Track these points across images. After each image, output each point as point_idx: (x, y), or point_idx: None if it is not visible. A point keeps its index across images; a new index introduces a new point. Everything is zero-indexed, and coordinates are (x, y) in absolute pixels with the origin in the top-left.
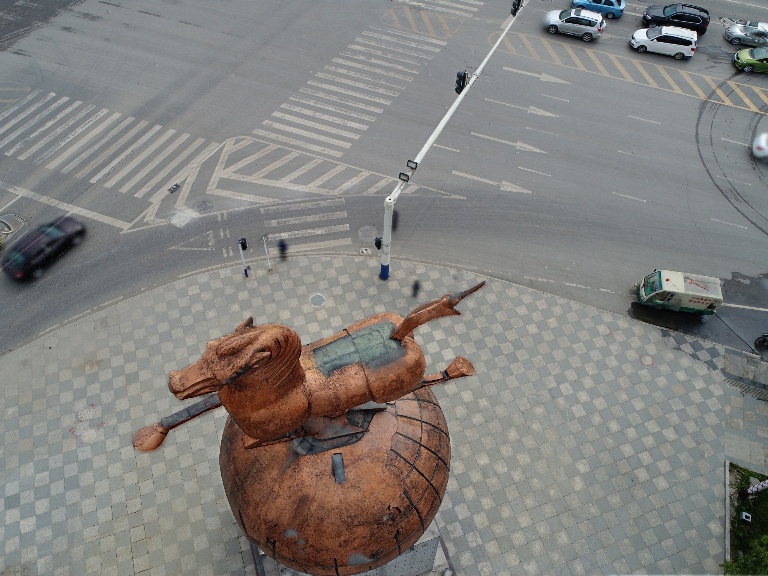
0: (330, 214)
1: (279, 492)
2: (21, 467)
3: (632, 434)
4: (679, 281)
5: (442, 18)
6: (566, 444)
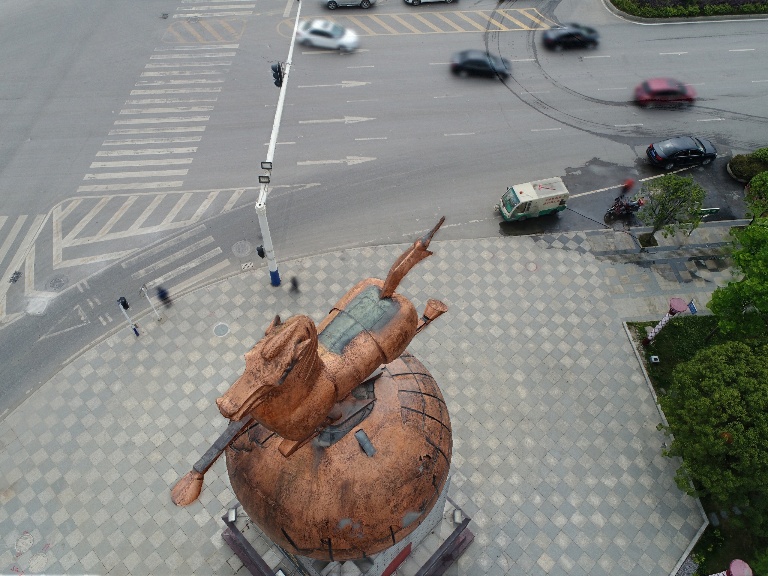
0: (196, 244)
1: (319, 491)
2: None
3: (546, 332)
4: (530, 190)
5: (224, 22)
6: (498, 364)
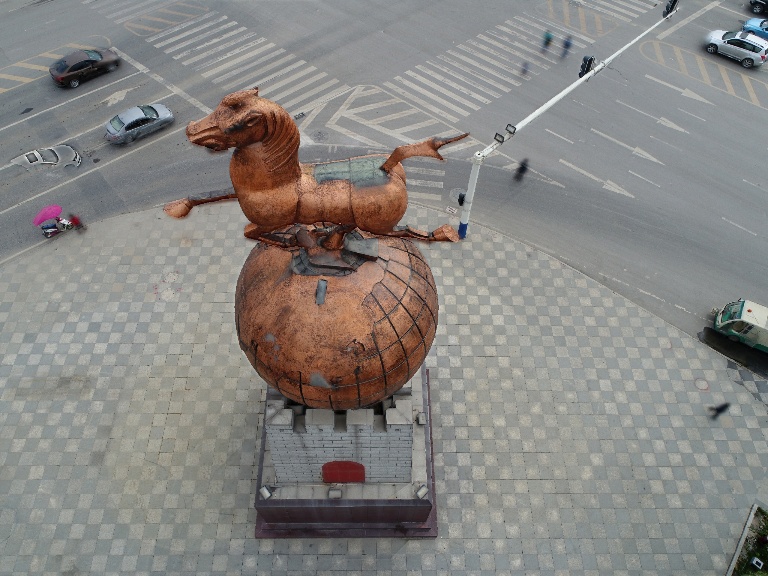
0: (429, 170)
1: (269, 300)
2: (109, 303)
3: (660, 447)
4: (762, 315)
5: (598, 18)
6: (587, 434)
